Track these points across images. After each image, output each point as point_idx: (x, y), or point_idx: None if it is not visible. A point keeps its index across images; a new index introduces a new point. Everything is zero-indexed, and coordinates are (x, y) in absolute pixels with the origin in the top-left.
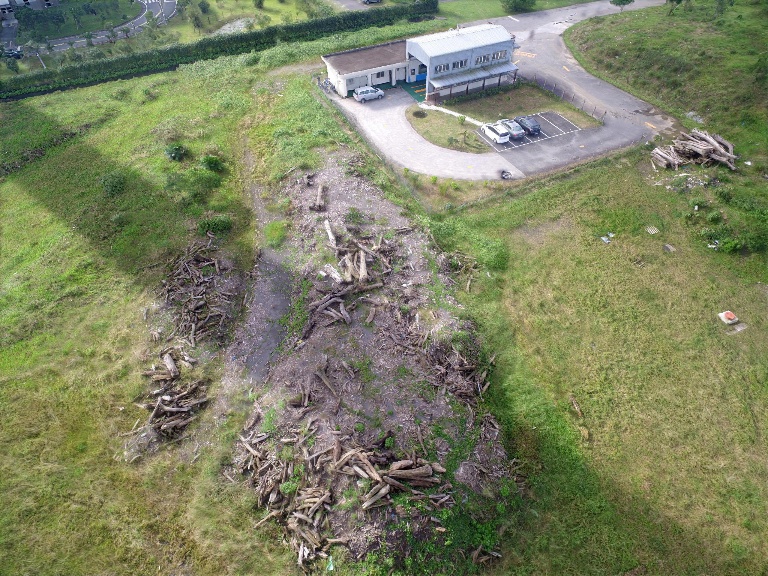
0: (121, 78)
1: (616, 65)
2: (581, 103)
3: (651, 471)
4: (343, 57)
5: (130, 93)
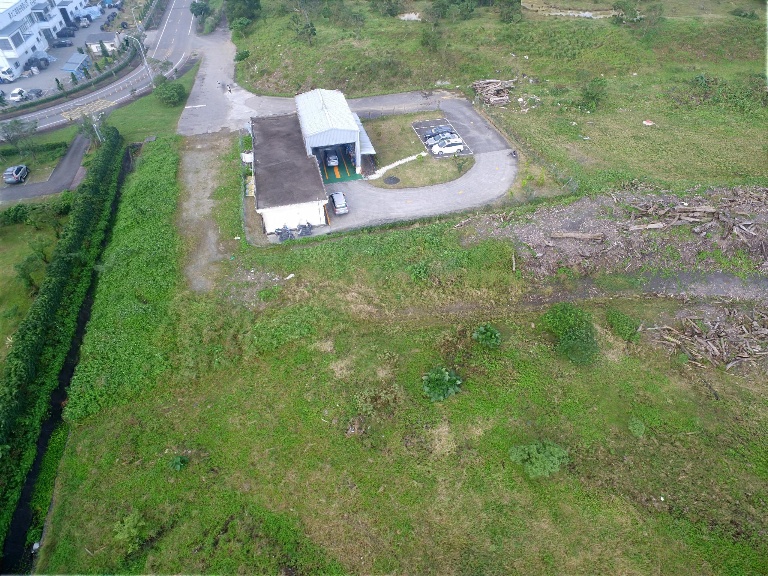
0: (3, 565)
1: (357, 84)
2: (402, 111)
3: (767, 164)
4: (268, 196)
5: (150, 506)
